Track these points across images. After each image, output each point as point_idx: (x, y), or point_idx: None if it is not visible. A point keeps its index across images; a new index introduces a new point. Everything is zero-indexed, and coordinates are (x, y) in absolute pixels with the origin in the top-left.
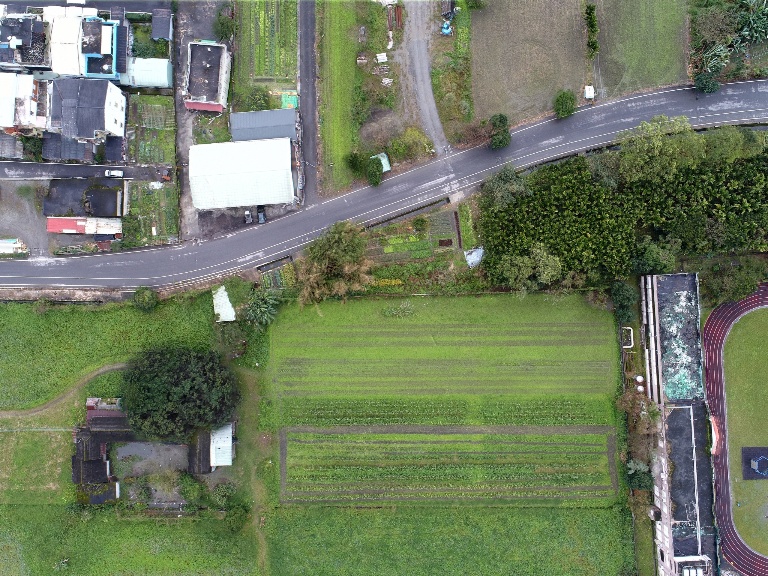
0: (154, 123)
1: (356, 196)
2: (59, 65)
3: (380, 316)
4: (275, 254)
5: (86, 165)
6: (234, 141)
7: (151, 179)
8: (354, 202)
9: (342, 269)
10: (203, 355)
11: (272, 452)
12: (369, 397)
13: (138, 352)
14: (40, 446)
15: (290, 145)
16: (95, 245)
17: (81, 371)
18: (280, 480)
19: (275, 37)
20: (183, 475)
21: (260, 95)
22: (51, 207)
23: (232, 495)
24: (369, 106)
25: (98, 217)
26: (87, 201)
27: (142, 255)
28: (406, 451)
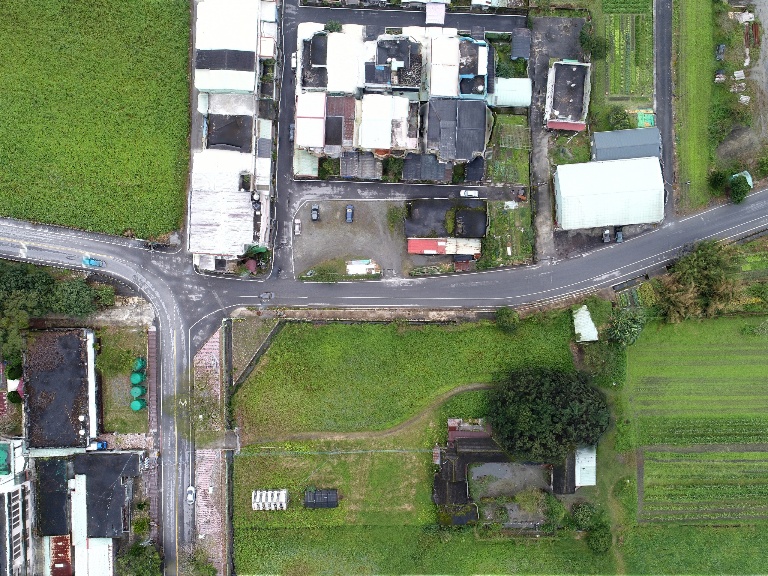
0: (513, 143)
1: (713, 214)
2: (440, 87)
3: (738, 334)
4: (631, 273)
5: (440, 185)
6: (600, 161)
7: (505, 199)
8: (711, 220)
9: (709, 288)
10: (569, 375)
11: (629, 471)
12: (727, 416)
13: (495, 372)
14: (395, 467)
15: (660, 164)
16: (450, 265)
17: (436, 392)
18: (637, 499)
19: (630, 55)
20: (546, 495)
21: (624, 114)
22: (413, 228)
23: (594, 515)
24: (730, 124)
25: (460, 238)
26: (460, 222)
27: (497, 275)
28: (765, 469)
